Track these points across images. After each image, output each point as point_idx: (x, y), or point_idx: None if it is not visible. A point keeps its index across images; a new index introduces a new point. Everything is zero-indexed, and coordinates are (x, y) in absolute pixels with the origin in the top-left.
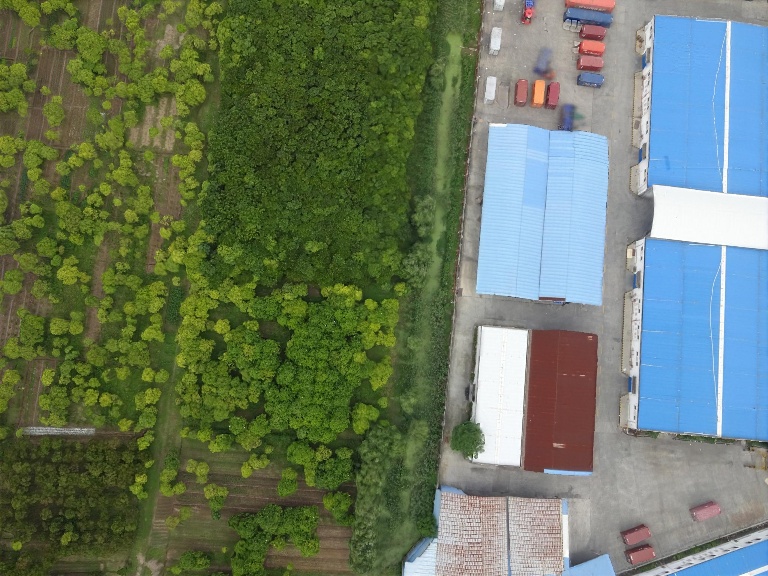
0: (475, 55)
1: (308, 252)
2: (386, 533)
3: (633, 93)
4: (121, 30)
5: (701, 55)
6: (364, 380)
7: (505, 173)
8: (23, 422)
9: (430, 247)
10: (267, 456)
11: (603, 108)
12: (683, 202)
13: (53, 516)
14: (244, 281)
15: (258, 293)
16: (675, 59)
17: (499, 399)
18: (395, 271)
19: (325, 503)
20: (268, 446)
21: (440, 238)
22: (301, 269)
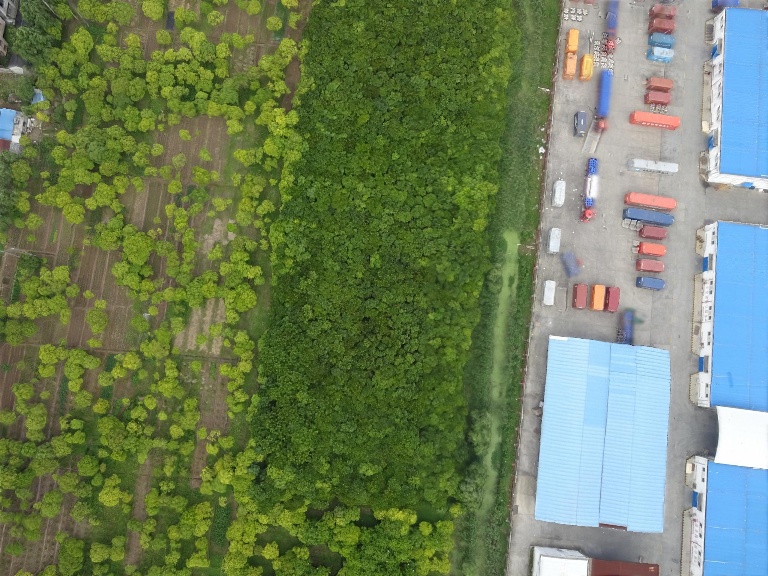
0: (533, 254)
1: (362, 476)
2: None
3: (693, 296)
4: (168, 223)
5: (765, 265)
6: None
7: (566, 391)
8: None
9: (485, 460)
10: None
11: (662, 312)
12: (748, 427)
13: None
14: (295, 507)
15: (308, 514)
16: (738, 268)
17: None
18: (451, 495)
19: None
20: None
21: (495, 450)
22: (355, 496)
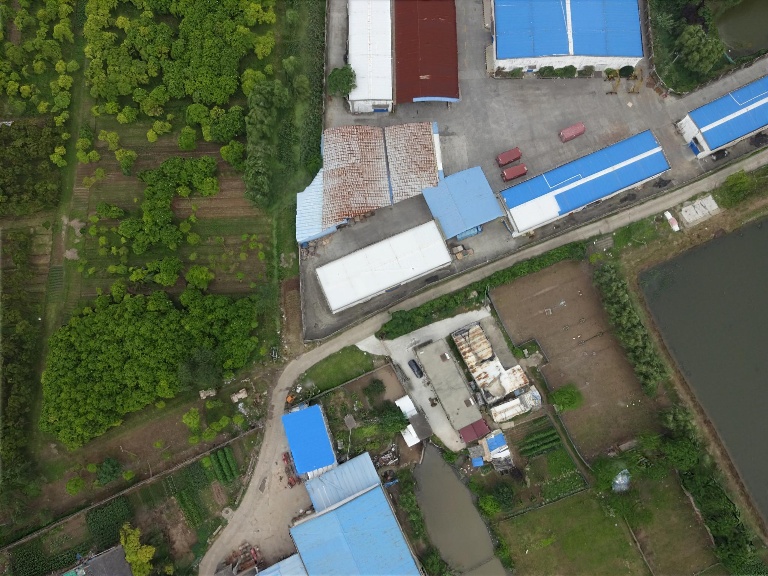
0: None
1: None
2: (281, 178)
3: None
4: None
5: None
6: (251, 55)
7: None
8: None
9: None
10: (169, 122)
11: None
12: None
13: None
14: None
15: None
16: None
17: (368, 47)
18: None
19: (221, 151)
20: None
21: None
22: None
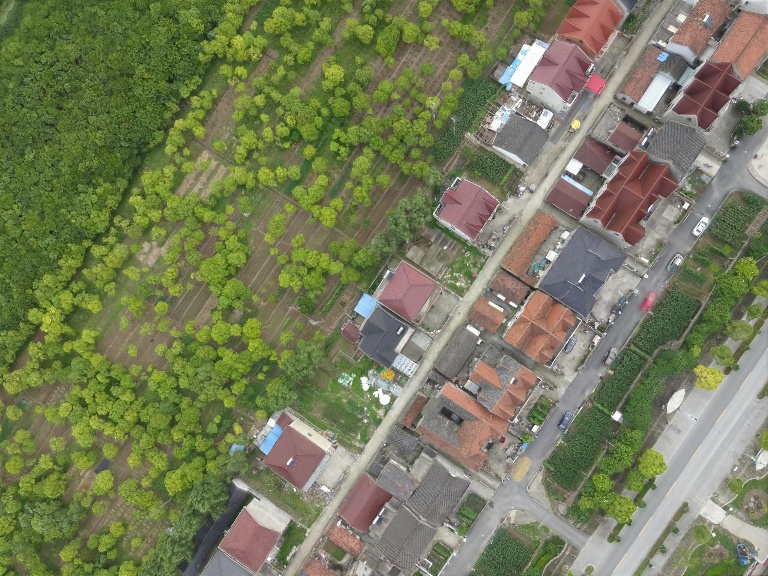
0: None
1: None
2: None
3: None
4: None
5: None
6: None
7: None
8: None
9: None
10: None
11: None
12: None
13: None
14: None
15: None
16: None
17: None
18: None
19: None
20: None
21: None
22: None
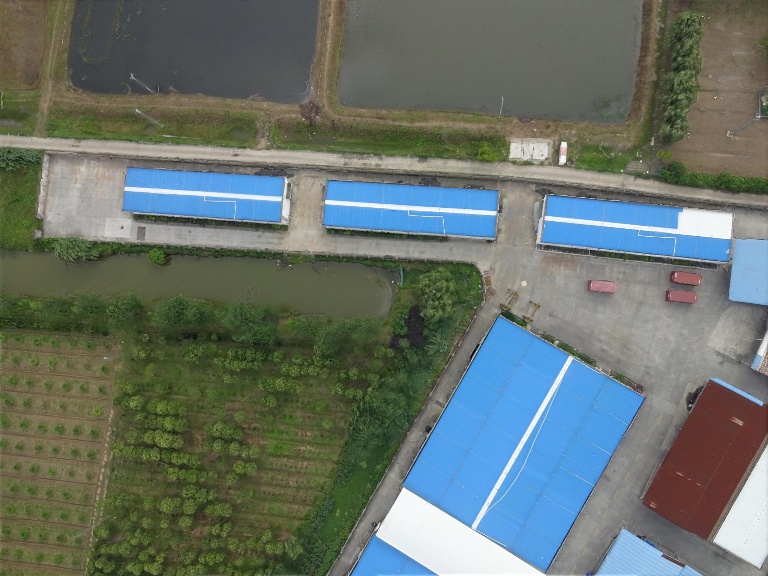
0: None
1: None
2: None
3: None
4: None
5: None
6: None
7: None
8: None
9: None
10: None
11: None
12: None
13: None
14: None
15: None
16: None
17: None
18: None
19: None
20: None
21: None
22: None
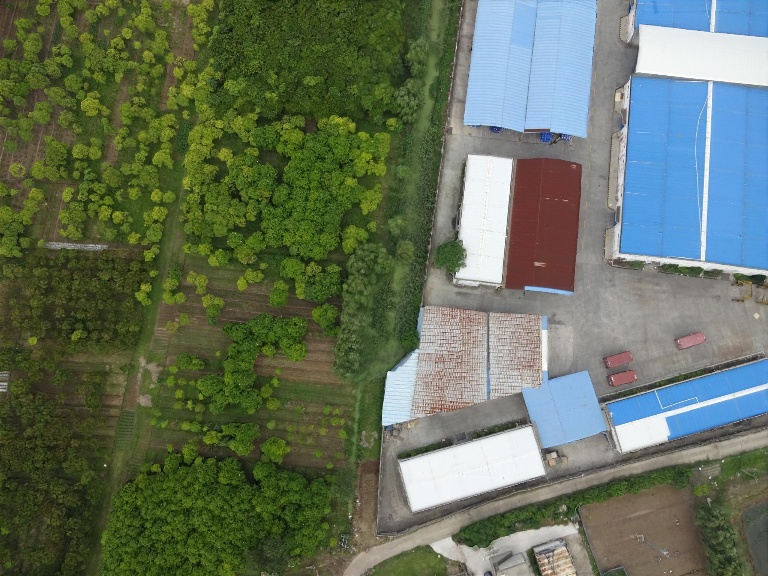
0: None
1: (306, 85)
2: (371, 348)
3: None
4: None
5: None
6: (355, 207)
7: (494, 16)
8: (45, 238)
9: (423, 90)
10: (262, 271)
11: None
12: (669, 39)
13: (66, 316)
14: (246, 111)
15: (260, 126)
16: None
17: (483, 221)
18: (387, 105)
19: (313, 313)
20: (263, 262)
21: (433, 82)
22: (298, 99)
